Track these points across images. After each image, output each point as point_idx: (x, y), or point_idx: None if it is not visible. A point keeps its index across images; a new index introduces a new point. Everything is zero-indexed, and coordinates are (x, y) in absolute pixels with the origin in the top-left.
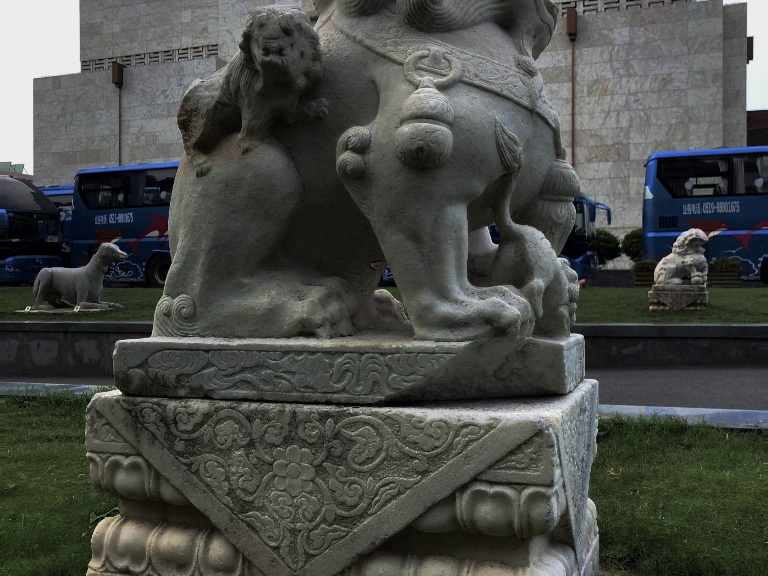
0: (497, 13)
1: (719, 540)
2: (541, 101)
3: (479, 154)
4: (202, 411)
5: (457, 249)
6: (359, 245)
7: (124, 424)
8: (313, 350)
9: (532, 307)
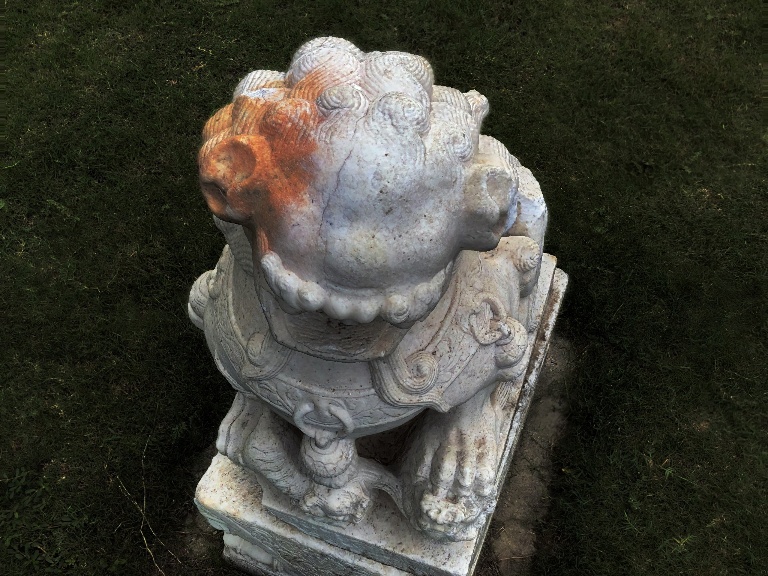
0: None
1: None
2: (258, 385)
3: None
4: None
5: None
6: None
7: None
8: None
9: None
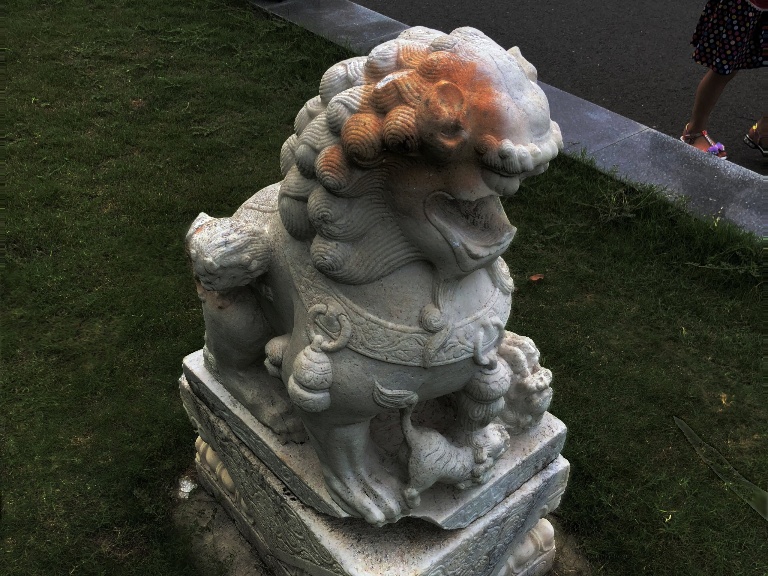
0: (415, 259)
1: (683, 575)
2: (444, 351)
3: (356, 409)
4: (224, 435)
5: (348, 452)
6: None
7: (194, 407)
8: (271, 450)
9: (406, 504)
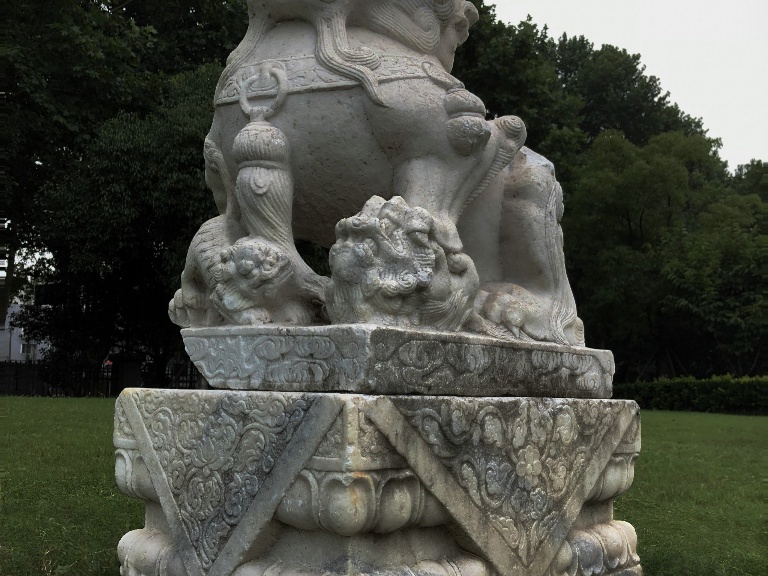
0: None
1: None
2: (225, 88)
3: None
4: None
5: None
6: None
7: None
8: None
9: None
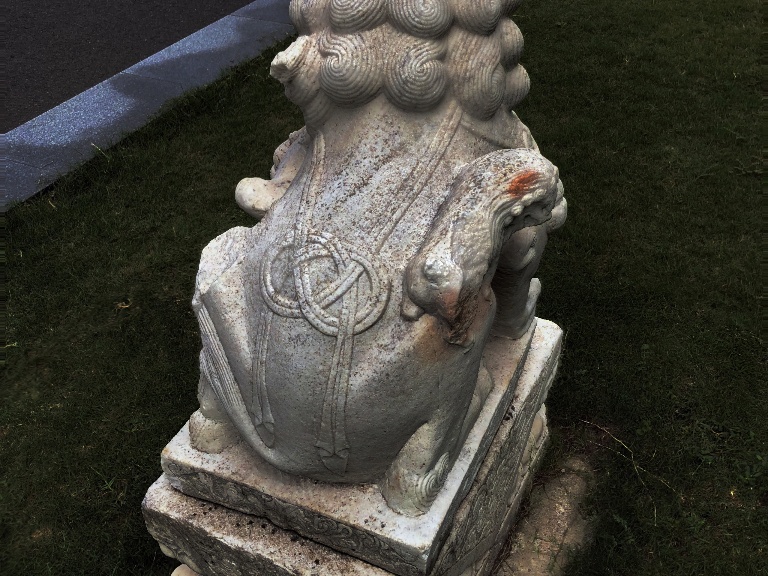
0: None
1: None
2: None
3: None
4: None
5: None
6: None
7: None
8: None
9: None
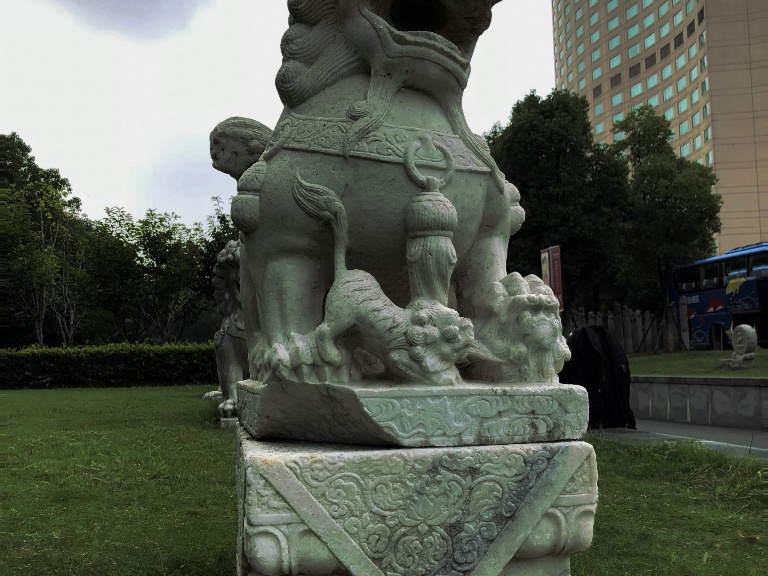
0: (355, 65)
1: None
2: (366, 142)
3: (279, 212)
4: None
5: (280, 300)
6: (325, 299)
7: None
8: (248, 390)
9: (318, 352)
